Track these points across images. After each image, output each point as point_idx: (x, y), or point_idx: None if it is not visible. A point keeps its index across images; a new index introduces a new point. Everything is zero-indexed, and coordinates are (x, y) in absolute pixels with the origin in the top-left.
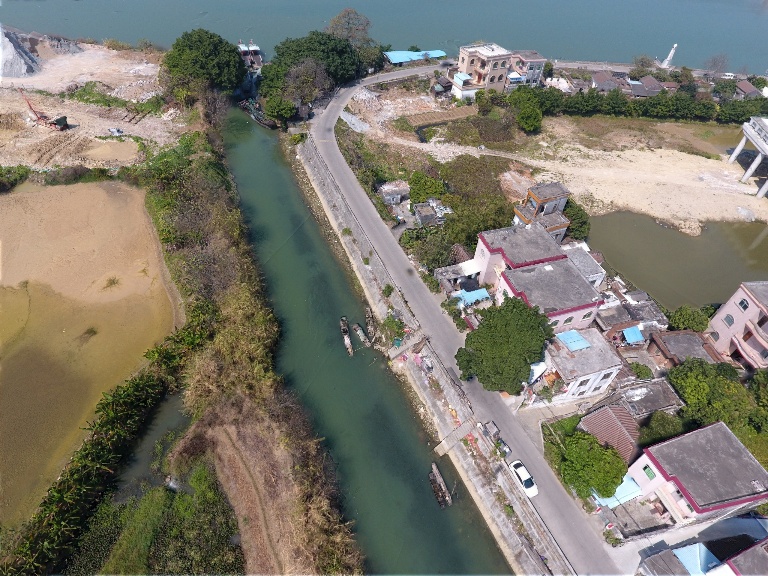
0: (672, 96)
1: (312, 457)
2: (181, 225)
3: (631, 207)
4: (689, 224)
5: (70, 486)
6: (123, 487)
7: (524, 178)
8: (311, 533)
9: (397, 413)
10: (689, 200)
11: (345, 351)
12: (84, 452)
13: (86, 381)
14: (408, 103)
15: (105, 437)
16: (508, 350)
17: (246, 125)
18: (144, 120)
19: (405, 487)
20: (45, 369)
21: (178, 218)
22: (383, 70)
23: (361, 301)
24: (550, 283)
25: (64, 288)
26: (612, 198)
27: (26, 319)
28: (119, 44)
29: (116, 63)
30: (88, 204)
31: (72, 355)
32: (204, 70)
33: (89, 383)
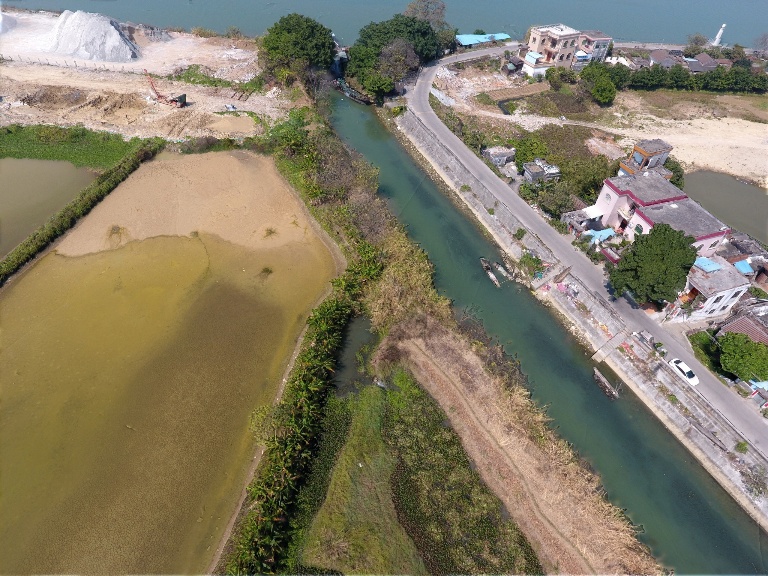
0: (731, 70)
1: (499, 359)
2: (318, 184)
3: (711, 167)
4: (767, 180)
5: (310, 379)
6: (341, 386)
7: (608, 144)
8: (520, 411)
9: (551, 331)
10: (763, 160)
11: (492, 284)
12: (310, 355)
13: (277, 308)
14: (484, 81)
15: (321, 345)
16: (665, 265)
17: (342, 102)
18: (251, 98)
19: (575, 386)
20: (239, 299)
21: (317, 177)
22: (457, 51)
23: (493, 245)
24: (679, 217)
25: (231, 237)
26: (693, 159)
27: (208, 261)
28: (207, 32)
29: (208, 49)
30: (226, 169)
31: (258, 289)
32: (304, 51)
33: (281, 310)
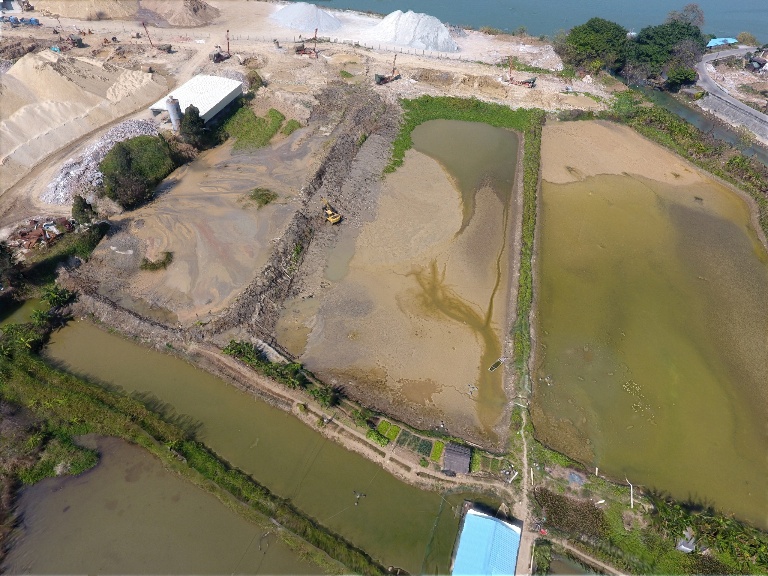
0: None
1: None
2: None
3: None
4: None
5: None
6: None
7: None
8: None
9: None
10: None
11: None
12: None
13: (728, 221)
14: (736, 76)
15: None
16: None
17: None
18: (574, 82)
19: None
20: (697, 214)
21: (690, 139)
22: (707, 51)
23: None
24: None
25: (652, 177)
26: None
27: (652, 191)
28: (496, 30)
29: (503, 44)
30: (602, 133)
31: (703, 209)
32: (615, 47)
33: (731, 222)
